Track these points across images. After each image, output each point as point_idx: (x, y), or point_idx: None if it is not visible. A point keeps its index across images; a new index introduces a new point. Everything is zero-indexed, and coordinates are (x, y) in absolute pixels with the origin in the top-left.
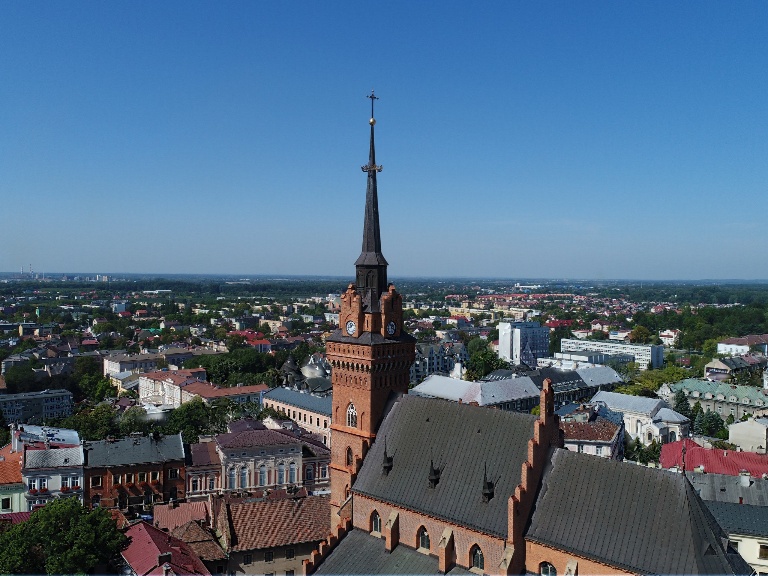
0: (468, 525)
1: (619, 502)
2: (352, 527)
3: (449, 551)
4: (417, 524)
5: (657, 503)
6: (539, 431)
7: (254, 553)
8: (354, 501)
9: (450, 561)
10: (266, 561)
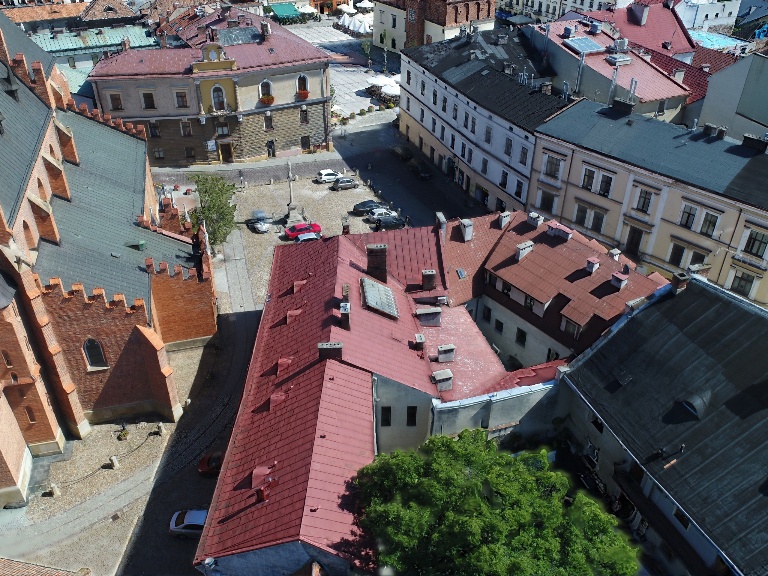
0: None
1: None
2: None
3: None
4: None
5: None
6: None
7: None
8: None
9: None
10: None
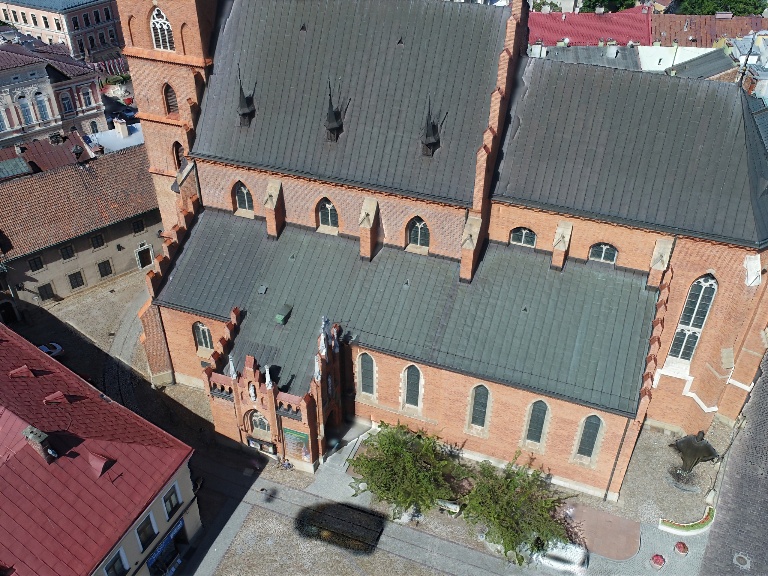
0: (405, 193)
1: (637, 135)
2: (202, 207)
3: (374, 230)
4: (315, 196)
5: (697, 131)
6: (514, 34)
7: (43, 254)
8: (199, 171)
9: (375, 242)
10: (64, 259)
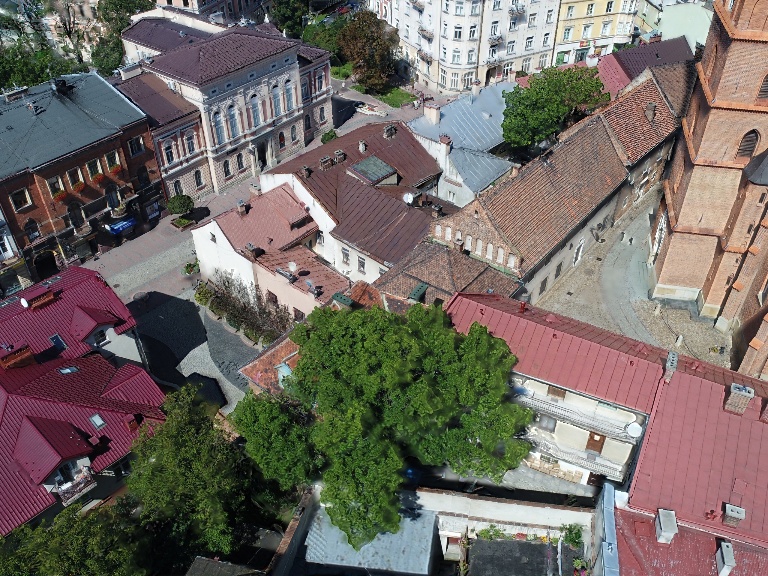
0: None
1: None
2: None
3: None
4: None
5: None
6: None
7: None
8: None
9: None
10: (545, 265)
